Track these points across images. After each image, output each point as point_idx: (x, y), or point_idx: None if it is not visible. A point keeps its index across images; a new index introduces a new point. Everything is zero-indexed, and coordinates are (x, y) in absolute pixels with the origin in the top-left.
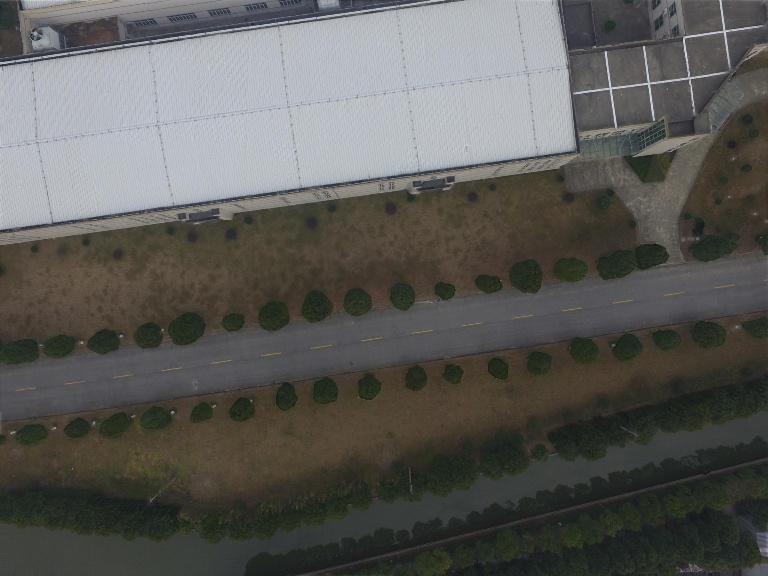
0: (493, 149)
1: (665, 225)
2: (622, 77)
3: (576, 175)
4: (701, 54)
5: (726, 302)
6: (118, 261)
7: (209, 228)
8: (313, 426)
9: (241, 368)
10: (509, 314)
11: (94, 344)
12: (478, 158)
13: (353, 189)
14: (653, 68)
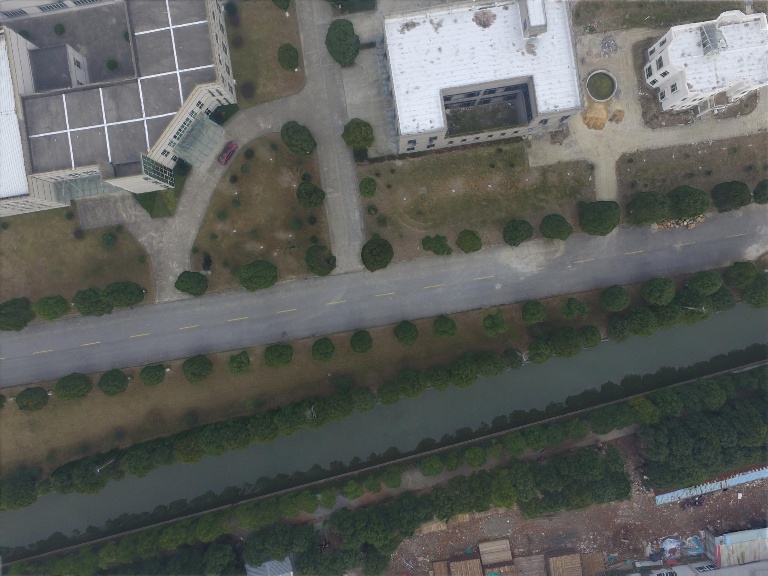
0: None
1: (178, 259)
2: (79, 119)
3: (88, 212)
4: (156, 94)
5: (240, 334)
6: None
7: None
8: None
9: None
10: (30, 349)
11: None
12: None
13: None
14: (109, 109)
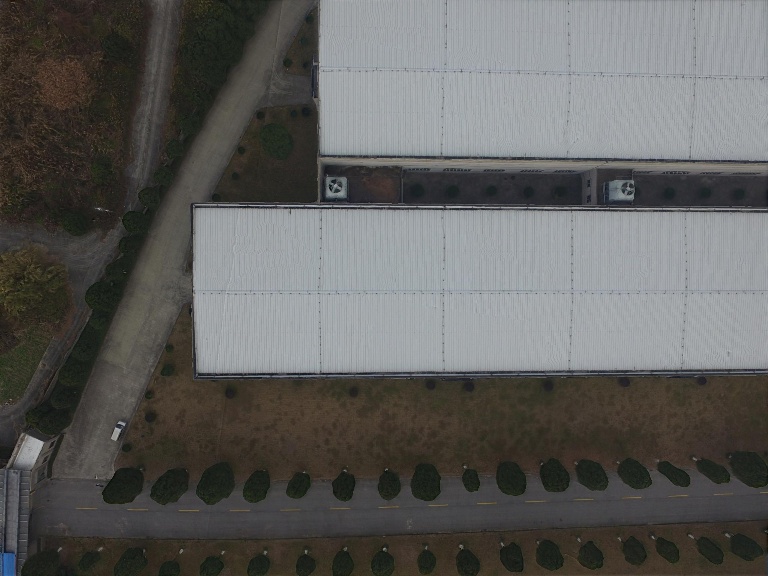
0: None
1: None
2: None
3: None
4: None
5: None
6: (352, 398)
7: None
8: (517, 575)
9: (456, 513)
10: (713, 490)
11: (346, 496)
12: (737, 364)
13: None
14: None
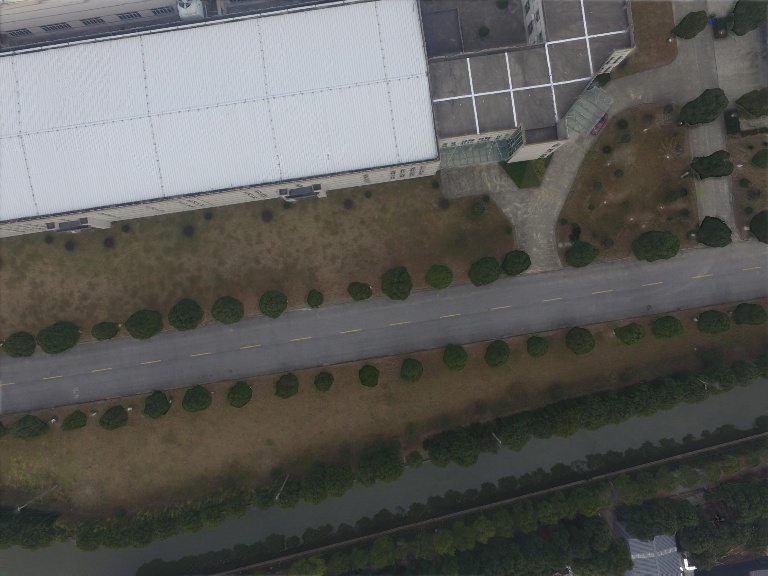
0: (355, 157)
1: (542, 231)
2: (484, 84)
3: (452, 181)
4: (563, 60)
5: (604, 307)
6: None
7: (87, 237)
8: (193, 433)
9: (121, 376)
10: (387, 321)
11: None
12: (340, 166)
13: (220, 197)
14: (515, 74)
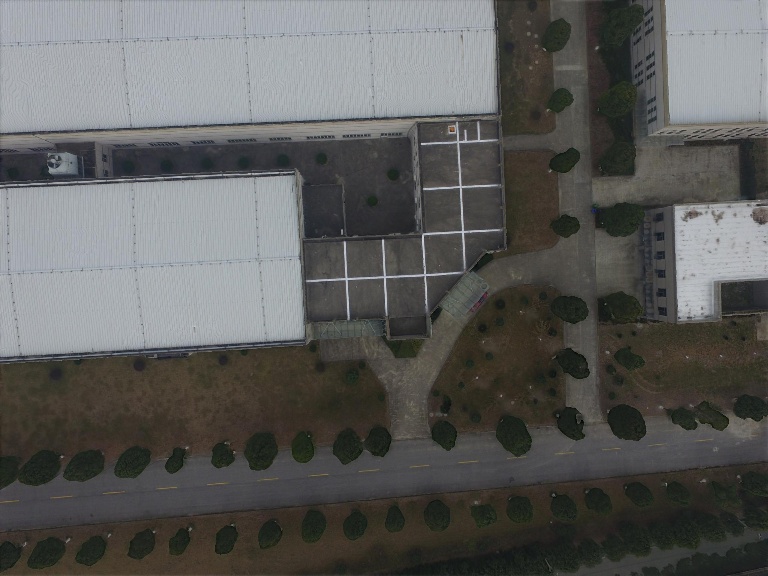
0: (221, 332)
1: (415, 399)
2: (359, 268)
3: (330, 345)
4: (438, 252)
5: (469, 477)
6: None
7: None
8: (47, 575)
9: None
10: (255, 476)
11: None
12: (206, 339)
13: None
14: (390, 262)
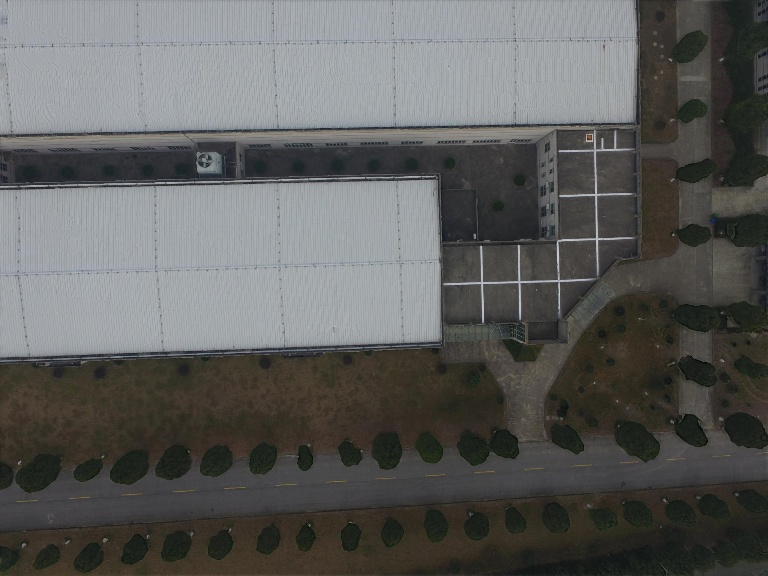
0: (360, 332)
1: (532, 402)
2: (494, 273)
3: (452, 347)
4: (572, 258)
5: (582, 480)
6: None
7: None
8: (168, 569)
9: (99, 505)
10: (373, 475)
11: None
12: (345, 339)
13: None
14: (525, 267)
